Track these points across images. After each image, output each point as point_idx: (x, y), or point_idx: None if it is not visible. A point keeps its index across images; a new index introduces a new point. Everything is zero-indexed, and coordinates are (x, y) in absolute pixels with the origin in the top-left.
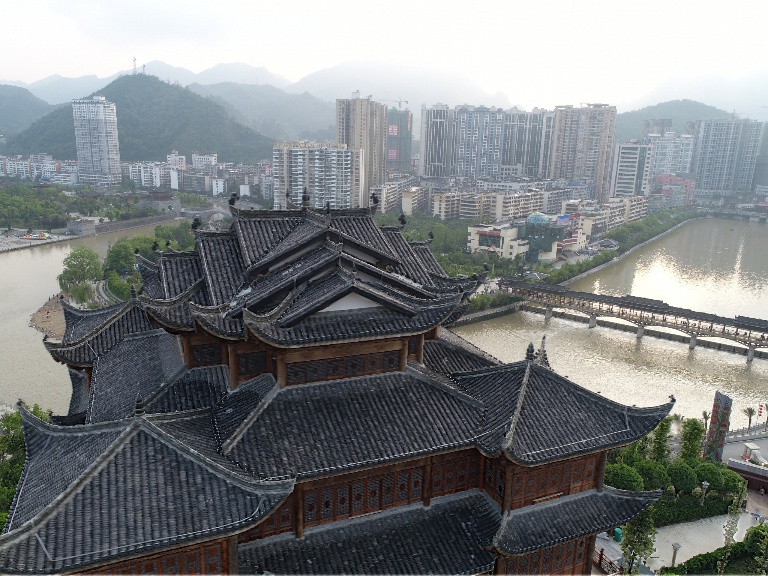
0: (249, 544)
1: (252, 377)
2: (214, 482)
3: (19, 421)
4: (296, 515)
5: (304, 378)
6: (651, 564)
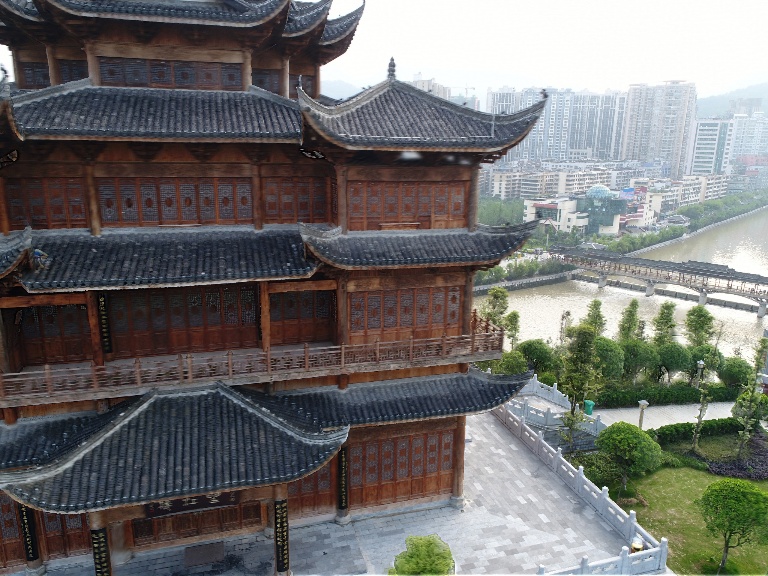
0: (33, 232)
1: None
2: None
3: None
4: (89, 207)
5: (123, 80)
6: None
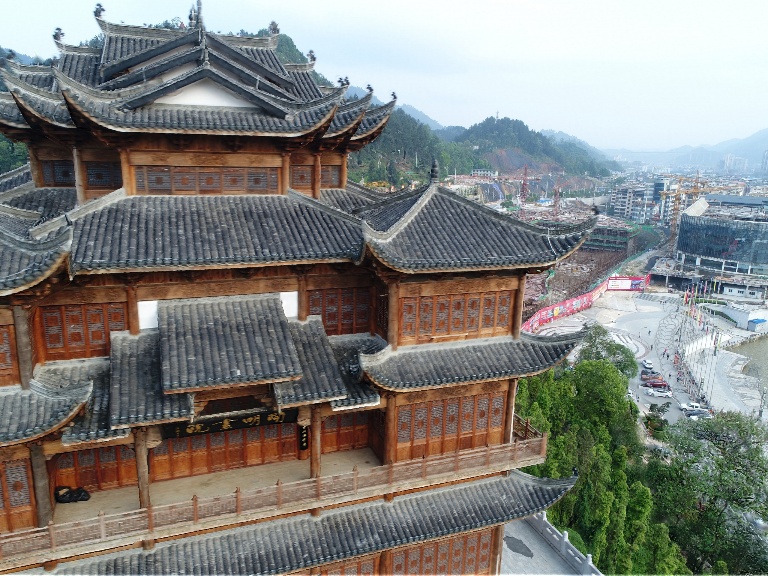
0: None
1: None
2: None
3: (582, 365)
4: None
5: None
6: None
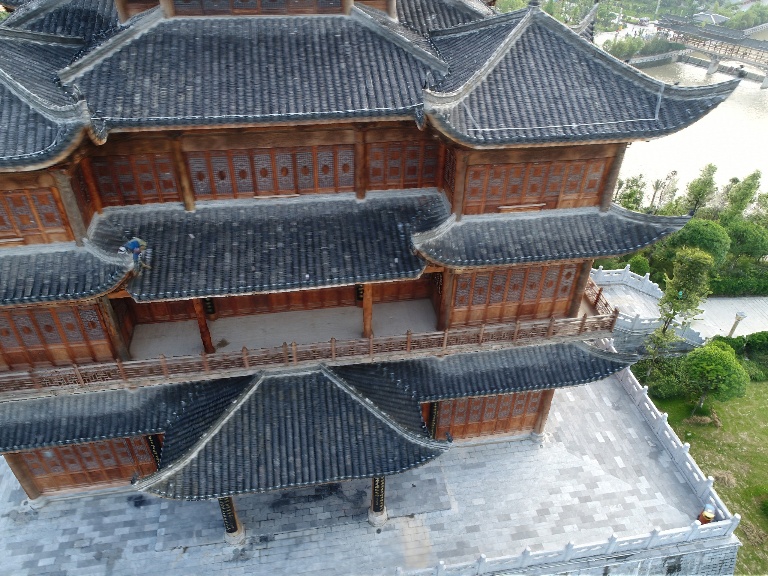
0: (126, 208)
1: (147, 8)
2: (14, 106)
3: None
4: (180, 182)
5: (200, 7)
6: (706, 332)
